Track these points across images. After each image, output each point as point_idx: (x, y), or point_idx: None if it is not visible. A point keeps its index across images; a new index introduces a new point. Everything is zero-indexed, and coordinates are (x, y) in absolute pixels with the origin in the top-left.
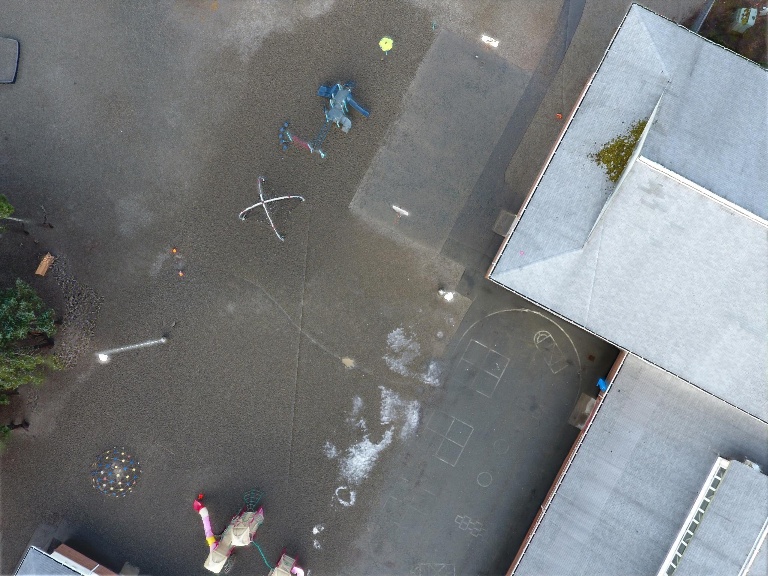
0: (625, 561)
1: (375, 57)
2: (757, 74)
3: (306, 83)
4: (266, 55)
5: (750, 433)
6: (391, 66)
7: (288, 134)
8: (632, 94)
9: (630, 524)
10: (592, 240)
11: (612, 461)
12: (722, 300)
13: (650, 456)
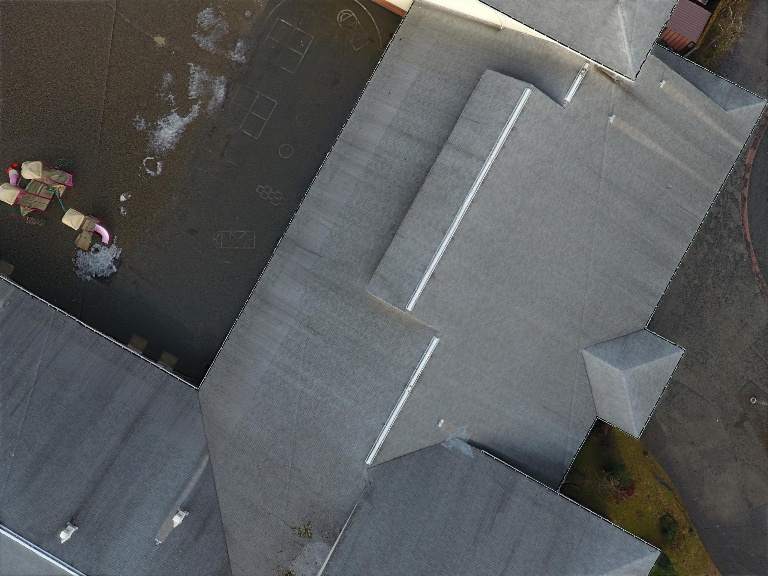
0: (393, 187)
1: None
2: None
3: None
4: None
5: (511, 57)
6: None
7: None
8: None
9: (400, 154)
10: None
11: (389, 101)
12: None
13: (422, 91)
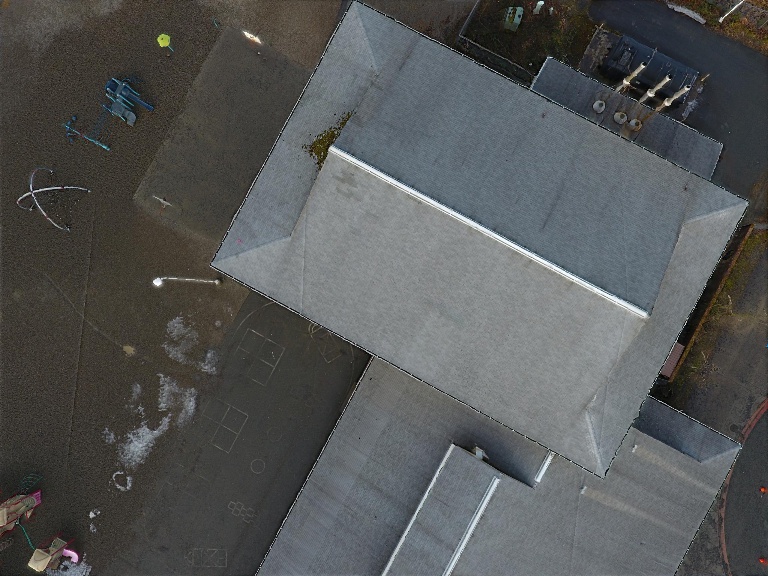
0: (363, 546)
1: (161, 53)
2: (470, 69)
3: (95, 78)
4: (57, 51)
5: (481, 421)
6: (177, 62)
7: (75, 127)
8: (345, 87)
9: (370, 510)
10: (298, 228)
11: (359, 448)
12: (420, 287)
13: (392, 443)
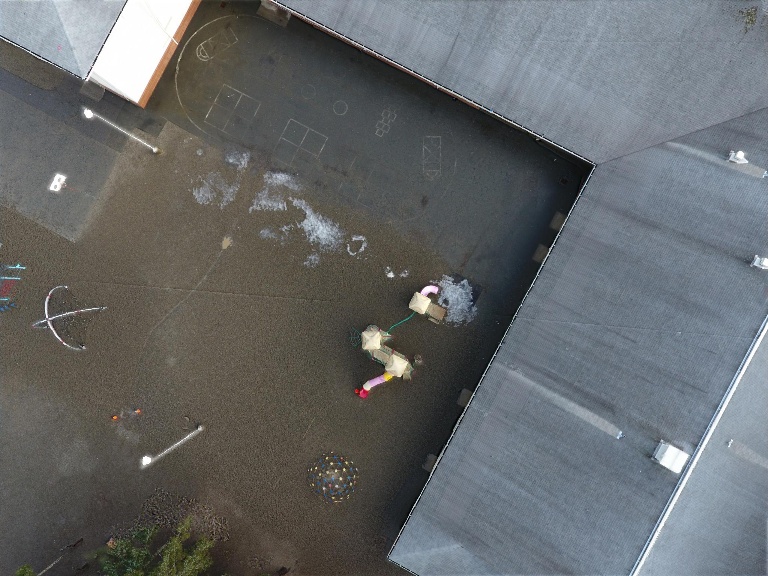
0: None
1: None
2: None
3: None
4: None
5: None
6: None
7: (1, 302)
8: None
9: None
10: None
11: None
12: None
13: None
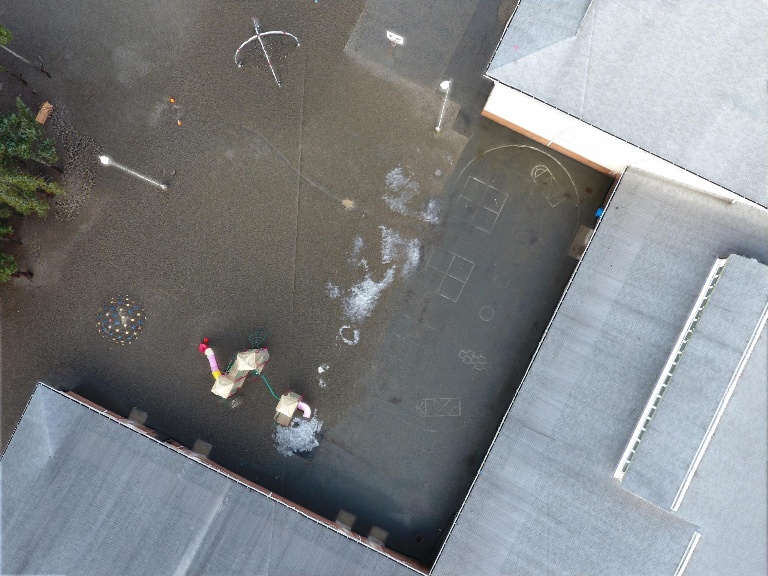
0: (628, 368)
1: None
2: None
3: None
4: None
5: (748, 233)
6: None
7: None
8: None
9: (632, 332)
10: (585, 25)
11: (612, 275)
12: (715, 78)
13: (649, 266)
